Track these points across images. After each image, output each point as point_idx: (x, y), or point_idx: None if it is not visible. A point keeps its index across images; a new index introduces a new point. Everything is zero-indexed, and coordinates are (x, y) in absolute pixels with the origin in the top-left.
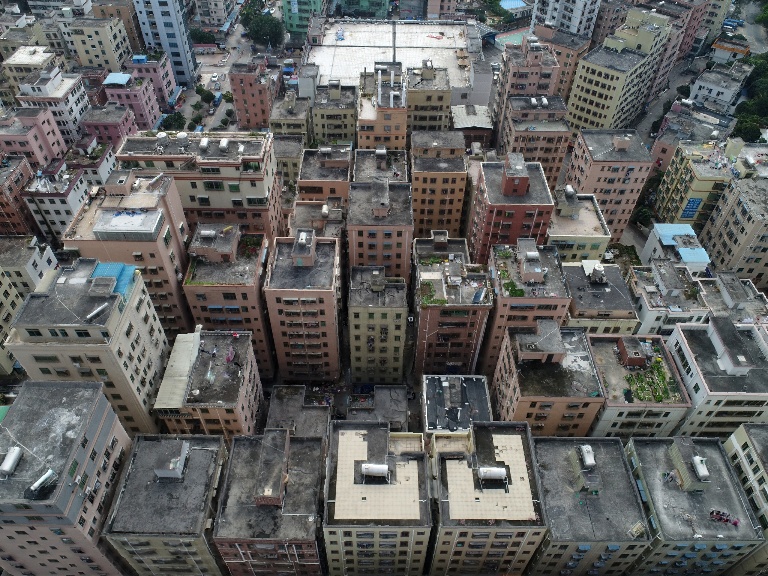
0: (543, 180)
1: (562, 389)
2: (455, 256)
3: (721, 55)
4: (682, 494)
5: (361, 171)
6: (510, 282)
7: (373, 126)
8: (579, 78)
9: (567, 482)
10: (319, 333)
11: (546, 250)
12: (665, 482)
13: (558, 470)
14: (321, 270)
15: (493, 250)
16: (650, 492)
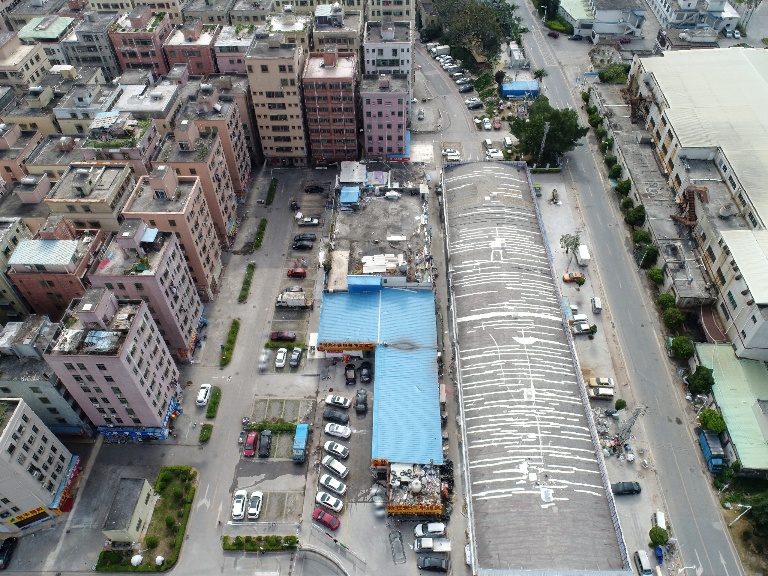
0: None
1: None
2: None
3: None
4: None
5: None
6: None
7: None
8: None
9: (202, 3)
10: None
11: None
12: (244, 2)
13: (201, 1)
14: None
15: None
16: None
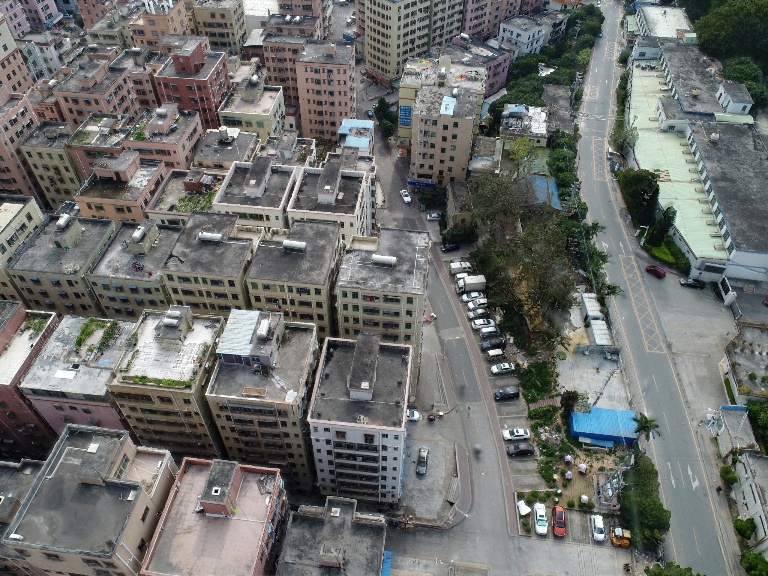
0: (218, 65)
1: (114, 196)
2: (123, 117)
3: (554, 7)
4: (129, 255)
5: (120, 65)
6: (140, 132)
7: (142, 31)
8: (367, 9)
9: (52, 242)
10: (3, 168)
11: (192, 115)
12: (124, 248)
13: None
14: (0, 114)
15: (147, 112)
16: (104, 251)
